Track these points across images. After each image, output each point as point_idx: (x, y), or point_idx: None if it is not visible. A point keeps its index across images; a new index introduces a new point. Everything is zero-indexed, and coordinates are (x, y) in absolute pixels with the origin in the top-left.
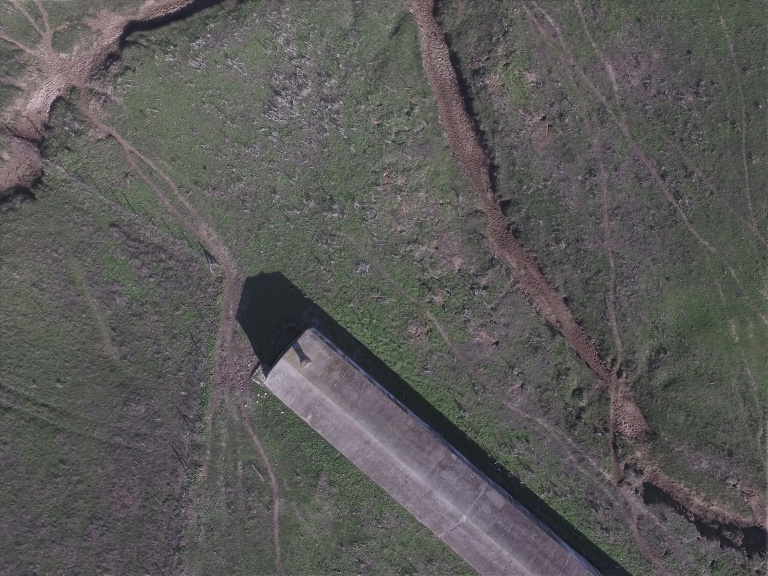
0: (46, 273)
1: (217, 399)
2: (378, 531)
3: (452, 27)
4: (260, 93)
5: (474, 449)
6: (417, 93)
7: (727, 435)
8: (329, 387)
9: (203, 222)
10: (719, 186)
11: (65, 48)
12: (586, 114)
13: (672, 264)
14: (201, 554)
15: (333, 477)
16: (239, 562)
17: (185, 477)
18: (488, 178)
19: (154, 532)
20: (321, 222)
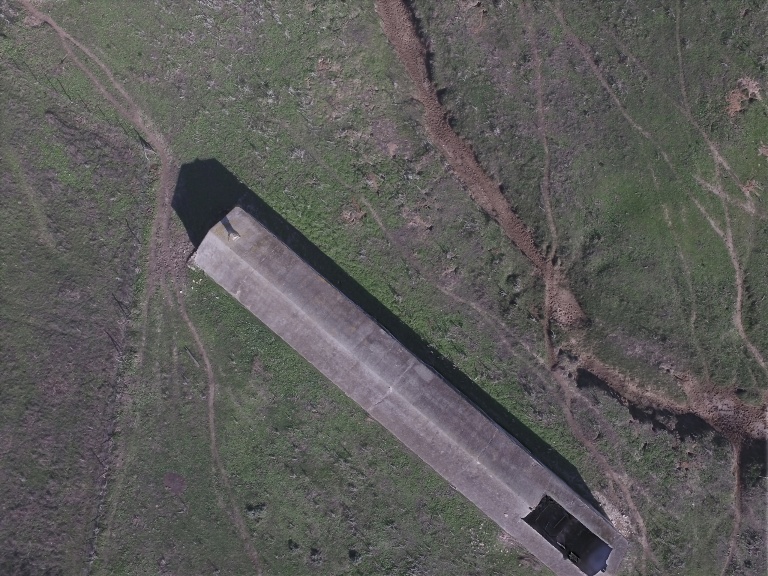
0: None
1: (153, 286)
2: (313, 416)
3: None
4: None
5: (408, 333)
6: None
7: (660, 320)
8: (257, 260)
9: (139, 109)
10: (653, 71)
11: None
12: (521, 0)
13: (606, 149)
14: (136, 439)
15: (268, 362)
16: (174, 447)
17: (121, 363)
18: (425, 68)
19: (89, 418)
20: (256, 109)
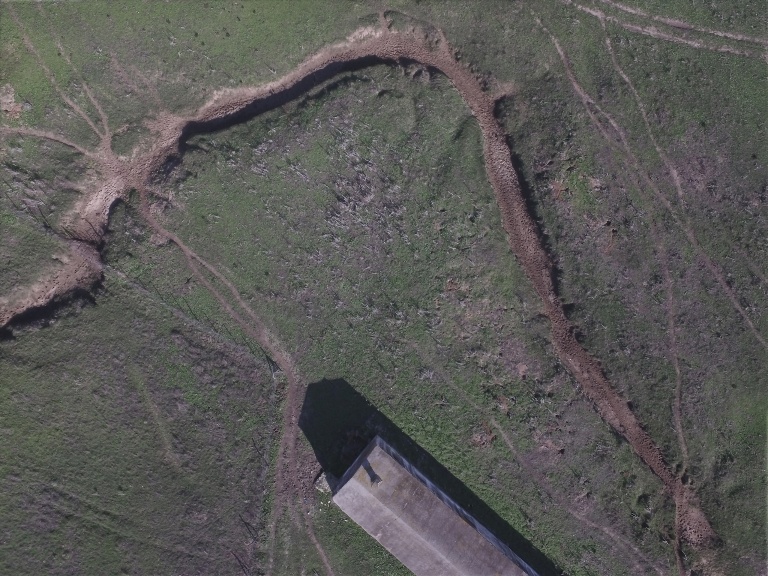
0: (107, 380)
1: (280, 506)
2: None
3: (514, 129)
4: (322, 198)
5: (540, 558)
6: (480, 198)
7: None
8: (400, 507)
9: (265, 328)
10: None
11: (125, 151)
12: (651, 219)
13: (738, 371)
14: None
15: None
16: None
17: None
18: (550, 280)
19: None
20: (384, 328)
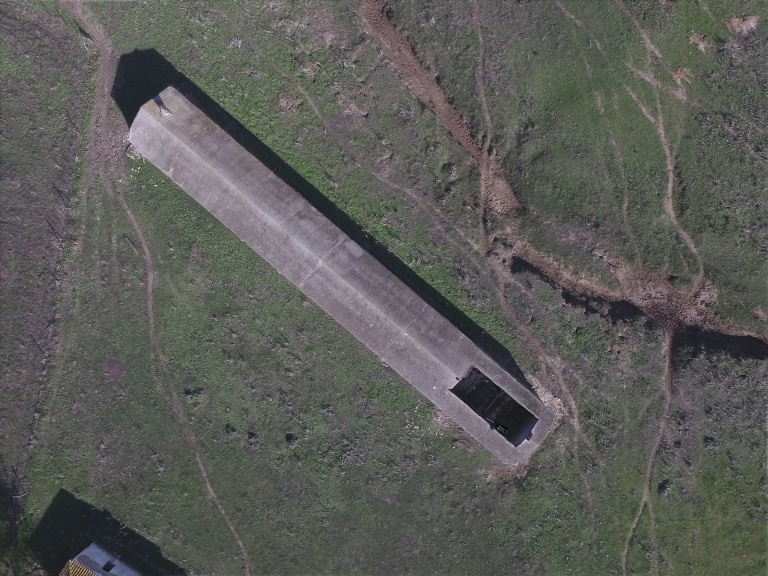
0: None
1: (92, 174)
2: (250, 302)
3: None
4: None
5: (344, 219)
6: None
7: (593, 206)
8: (188, 137)
9: (78, 0)
10: None
11: None
12: None
13: (539, 38)
14: (76, 326)
15: (205, 249)
16: (113, 334)
17: (60, 251)
18: None
19: (30, 305)
20: None
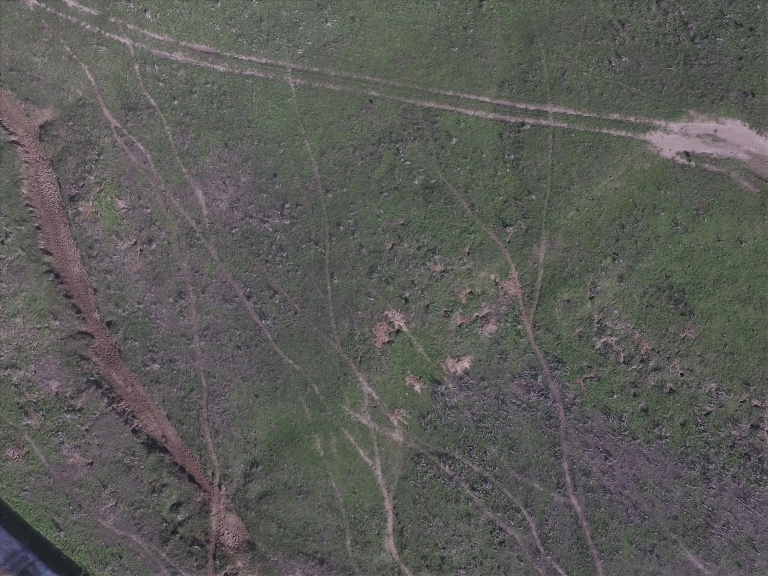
0: None
1: None
2: None
3: (54, 153)
4: None
5: (71, 567)
6: (13, 221)
7: (317, 545)
8: None
9: None
10: (303, 306)
11: None
12: (176, 238)
13: (260, 382)
14: None
15: None
16: None
17: None
18: None
19: None
20: None
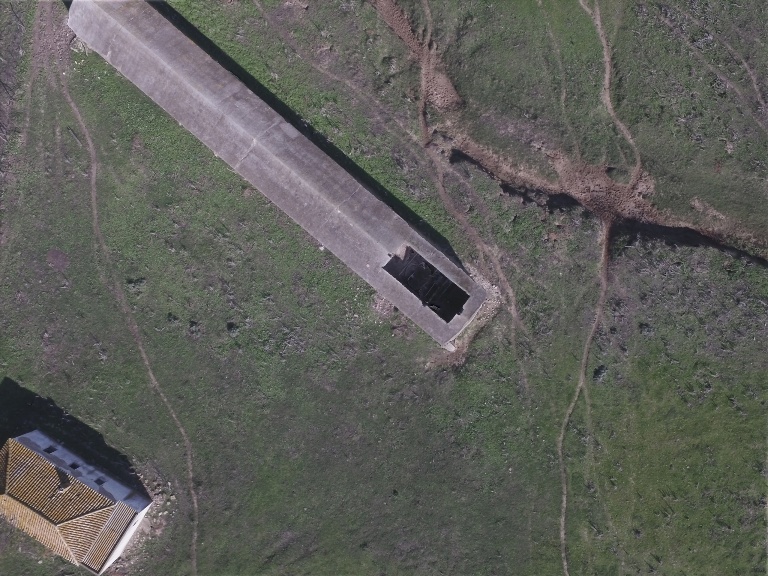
0: None
1: (36, 68)
2: (192, 193)
3: None
4: None
5: (284, 110)
6: None
7: (531, 98)
8: (125, 19)
9: None
10: None
11: None
12: None
13: None
14: (20, 217)
15: (148, 140)
16: (57, 225)
17: (5, 144)
18: None
19: None
20: None
